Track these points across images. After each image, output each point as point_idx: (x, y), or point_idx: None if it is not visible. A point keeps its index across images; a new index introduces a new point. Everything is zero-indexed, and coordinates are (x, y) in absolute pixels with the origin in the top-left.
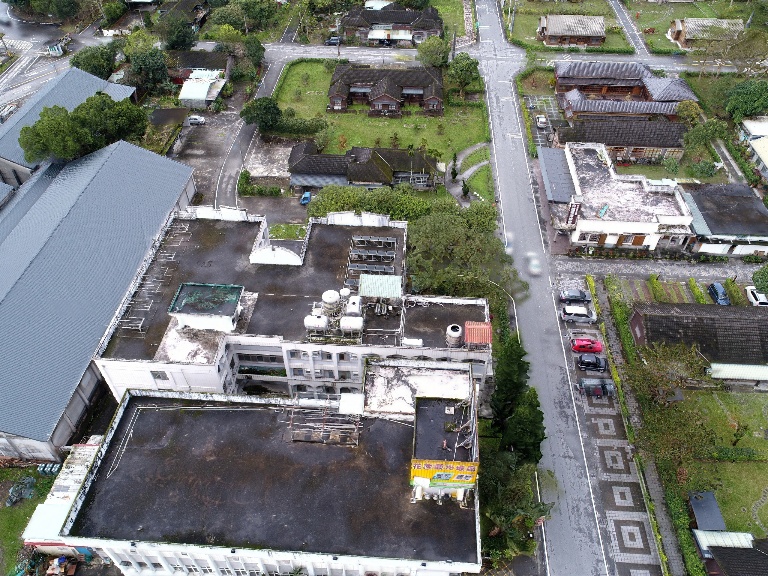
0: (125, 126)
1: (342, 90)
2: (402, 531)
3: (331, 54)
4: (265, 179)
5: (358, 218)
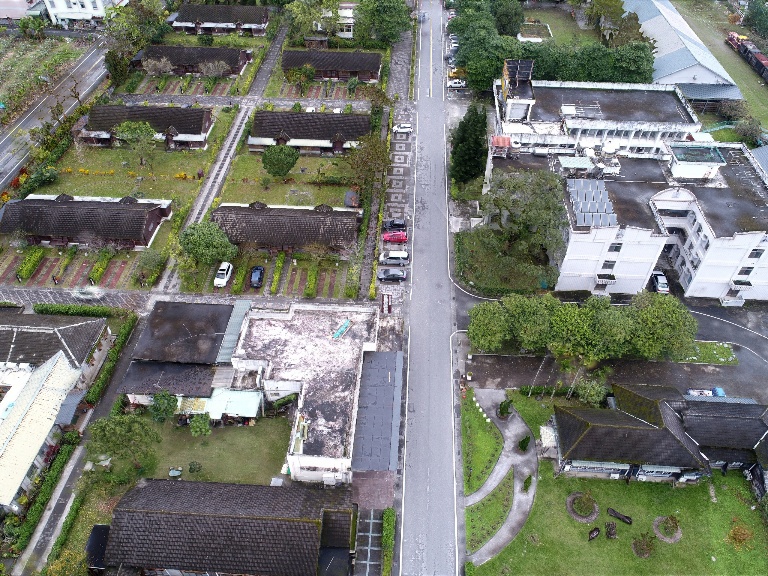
0: None
1: None
2: None
3: None
4: None
5: None
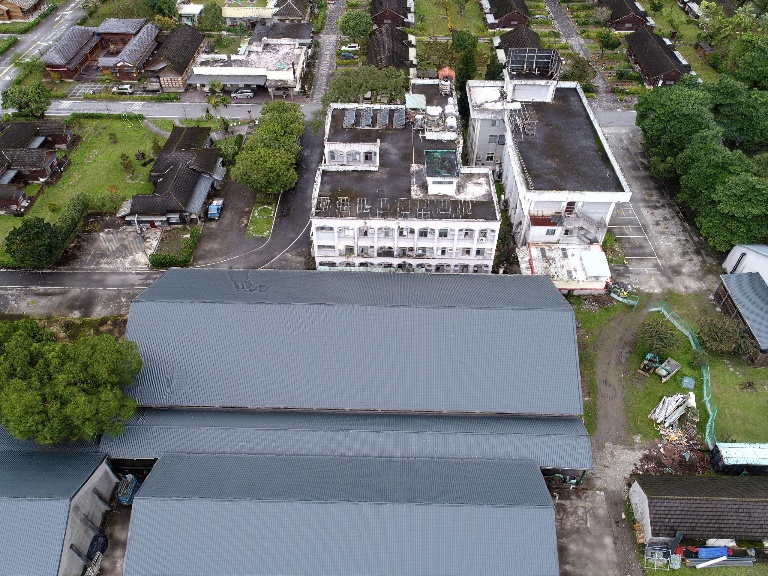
0: None
1: (8, 185)
2: None
3: None
4: (160, 250)
5: None
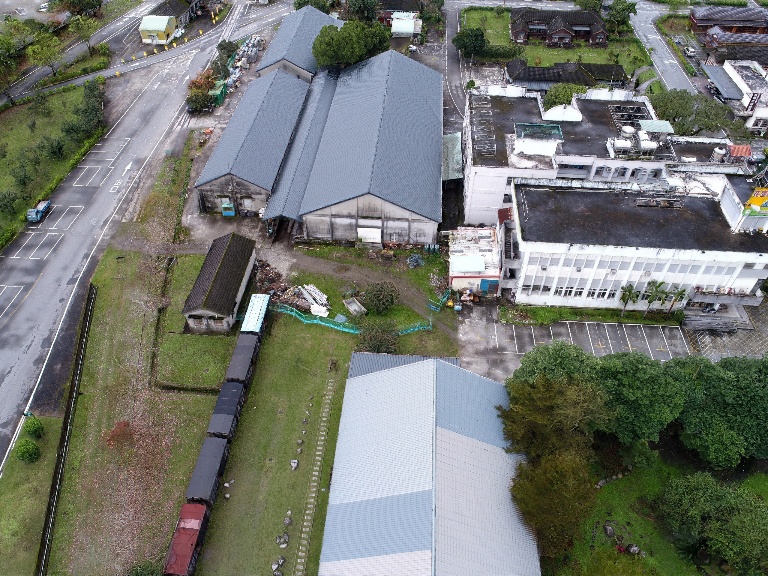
0: (378, 44)
1: (525, 26)
2: (734, 246)
3: (493, 4)
4: None
5: (610, 93)
